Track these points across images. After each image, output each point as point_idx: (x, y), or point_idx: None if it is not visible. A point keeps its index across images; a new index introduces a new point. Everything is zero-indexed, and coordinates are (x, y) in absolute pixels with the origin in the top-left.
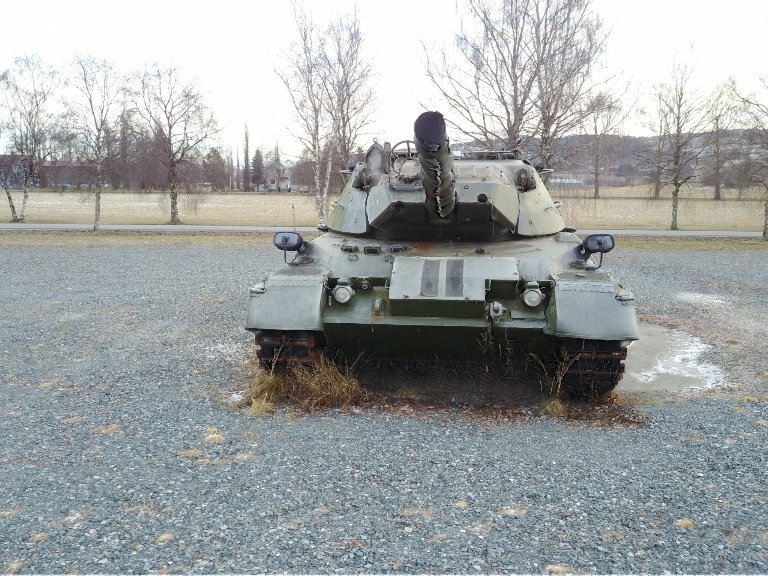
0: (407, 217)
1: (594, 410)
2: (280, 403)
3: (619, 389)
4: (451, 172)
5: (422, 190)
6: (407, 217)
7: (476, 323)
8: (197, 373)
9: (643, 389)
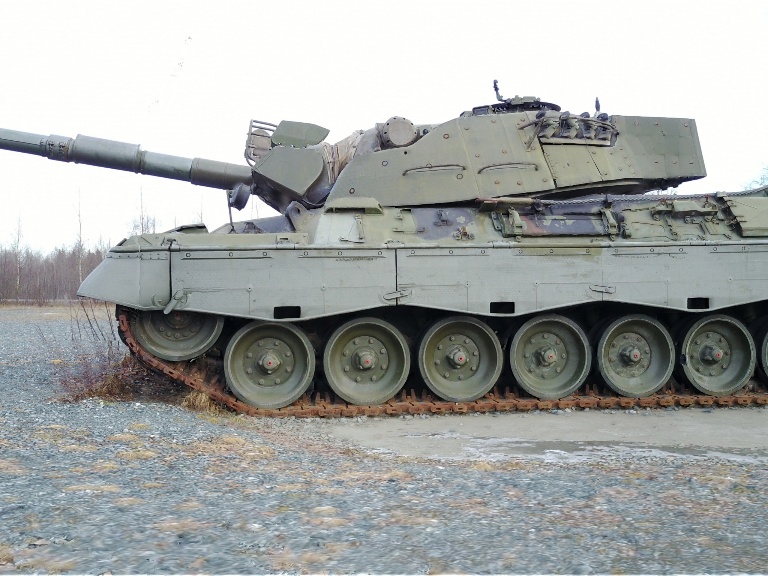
0: None
1: None
2: None
3: (332, 427)
4: (77, 138)
5: None
6: None
7: None
8: None
9: (345, 434)
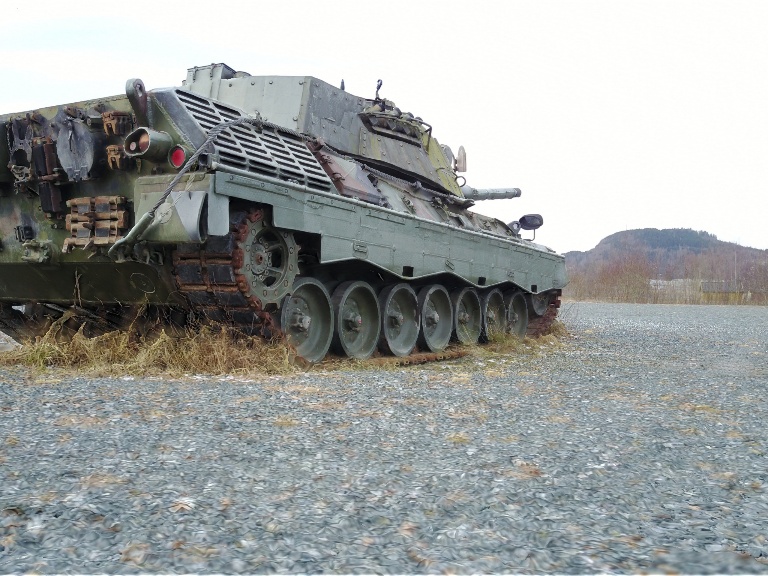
0: None
1: None
2: None
3: None
4: None
5: None
6: None
7: None
8: None
9: None
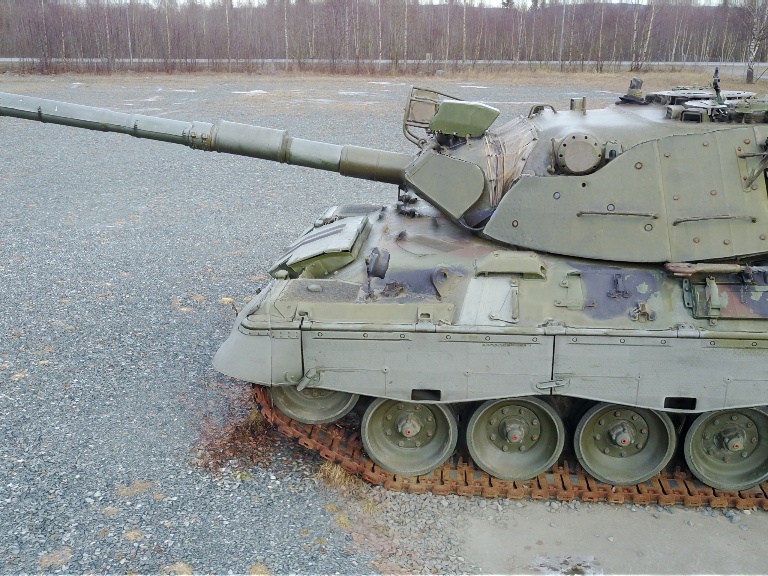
0: None
1: (291, 456)
2: None
3: (468, 522)
4: (219, 128)
5: None
6: None
7: None
8: None
9: (477, 548)
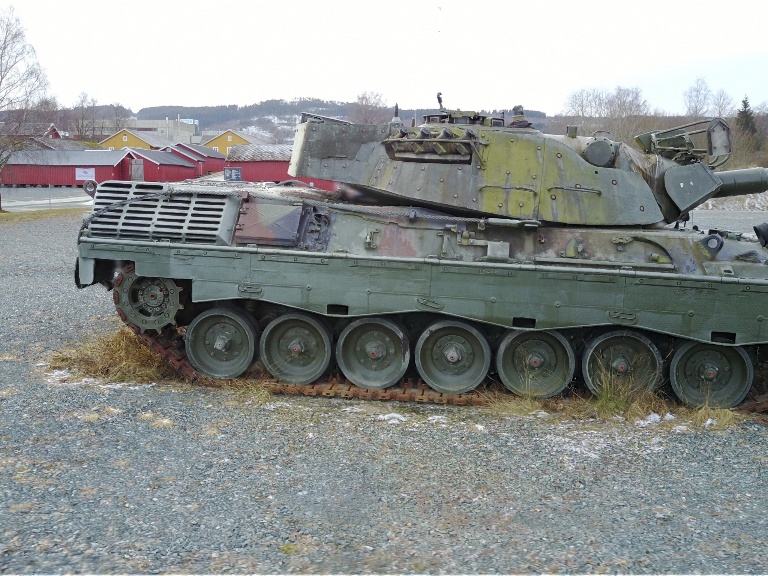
0: None
1: None
2: None
3: None
4: None
5: None
6: None
7: None
8: None
9: None
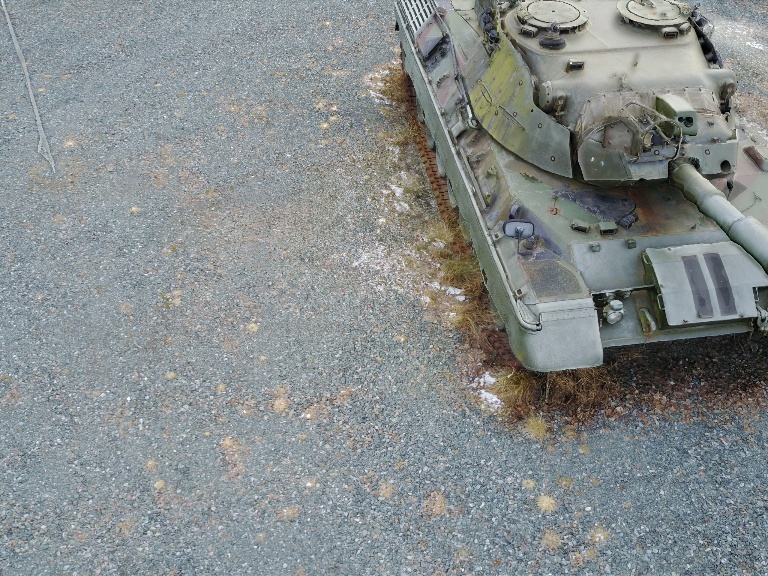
0: (640, 186)
1: None
2: (538, 403)
3: None
4: None
5: (663, 161)
6: (640, 186)
7: (740, 329)
8: (404, 341)
9: None
